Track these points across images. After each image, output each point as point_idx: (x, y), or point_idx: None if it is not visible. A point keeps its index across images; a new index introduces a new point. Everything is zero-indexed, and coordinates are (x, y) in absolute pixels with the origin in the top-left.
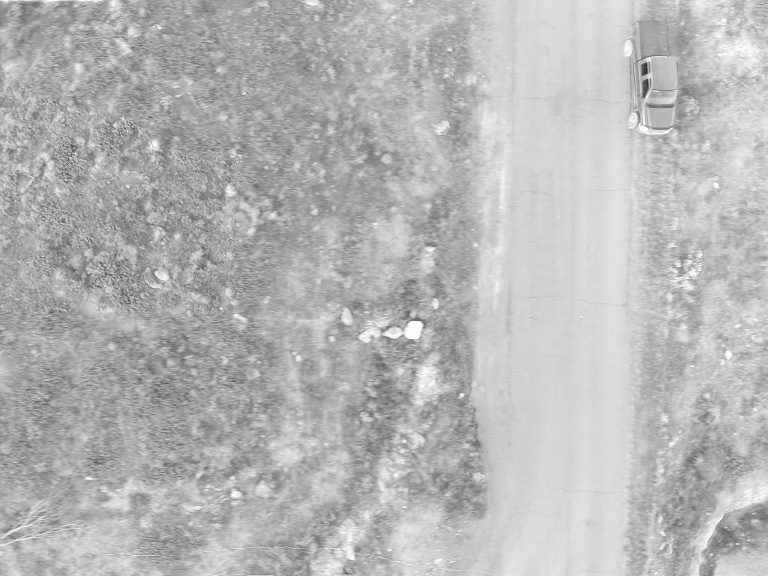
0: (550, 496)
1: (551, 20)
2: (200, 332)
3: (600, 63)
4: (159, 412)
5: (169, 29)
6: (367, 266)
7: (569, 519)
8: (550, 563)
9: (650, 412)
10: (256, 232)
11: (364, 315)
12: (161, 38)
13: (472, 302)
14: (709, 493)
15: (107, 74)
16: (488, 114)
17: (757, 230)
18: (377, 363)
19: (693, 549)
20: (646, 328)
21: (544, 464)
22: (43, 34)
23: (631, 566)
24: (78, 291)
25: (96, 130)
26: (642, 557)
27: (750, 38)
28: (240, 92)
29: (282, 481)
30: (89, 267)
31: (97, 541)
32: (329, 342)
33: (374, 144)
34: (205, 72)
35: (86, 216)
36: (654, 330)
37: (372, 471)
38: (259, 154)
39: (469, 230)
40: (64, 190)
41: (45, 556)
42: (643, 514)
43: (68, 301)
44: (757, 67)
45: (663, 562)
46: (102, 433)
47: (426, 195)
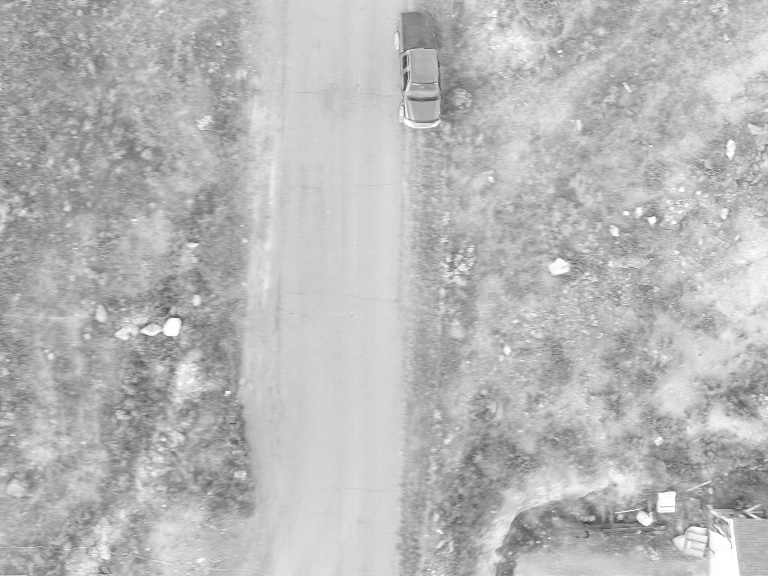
0: (320, 494)
1: (323, 13)
2: None
3: (372, 56)
4: None
5: None
6: (125, 263)
7: (340, 517)
8: (321, 562)
9: (423, 409)
10: (7, 229)
11: (119, 312)
12: None
13: (240, 298)
14: (493, 491)
15: None
16: (258, 109)
17: (534, 224)
18: (136, 360)
19: (480, 547)
20: (418, 324)
21: (314, 462)
22: None
23: (404, 565)
24: None
25: None
26: (416, 556)
27: (522, 30)
28: None
29: (36, 480)
30: None
31: None
32: (83, 339)
33: (134, 139)
34: None
35: None
36: (427, 326)
37: (130, 470)
38: (11, 150)
39: (237, 226)
40: None
41: None
42: (416, 512)
43: None
44: (532, 59)
45: (442, 561)
46: None
47: (190, 191)
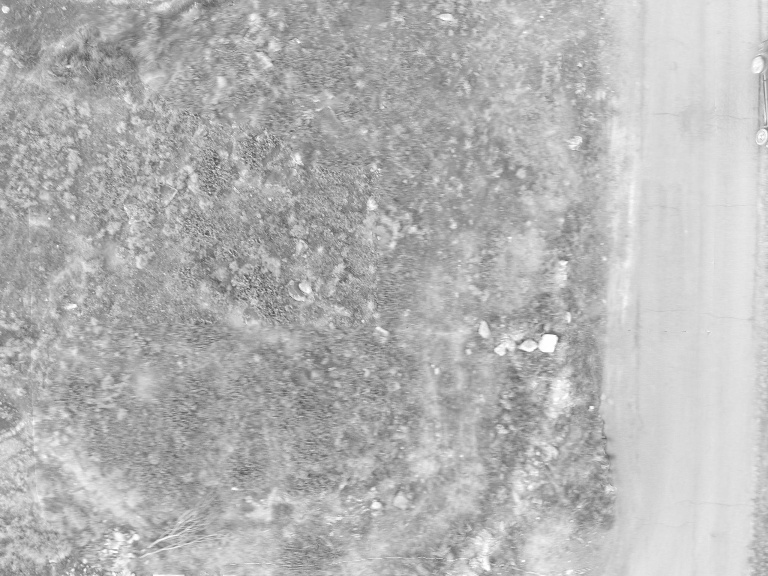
0: (677, 508)
1: (679, 36)
2: (343, 344)
3: (728, 79)
4: (303, 423)
5: (308, 43)
6: (502, 280)
7: (695, 531)
8: (676, 574)
9: None
10: (396, 245)
11: (501, 328)
12: (301, 52)
13: (601, 315)
14: None
15: (249, 88)
16: (617, 129)
17: None
18: (511, 376)
19: None
20: None
21: (671, 476)
22: (182, 47)
23: None
24: (223, 303)
25: (238, 143)
26: (766, 569)
27: None
28: (379, 106)
29: (419, 492)
30: (234, 279)
31: (240, 550)
32: (466, 355)
33: (509, 159)
34: (344, 86)
35: (229, 229)
36: None
37: (506, 483)
38: (399, 168)
39: (598, 244)
40: (208, 203)
41: (190, 565)
42: (767, 527)
43: (213, 313)
44: None
45: None
46: (247, 444)
47: (558, 209)
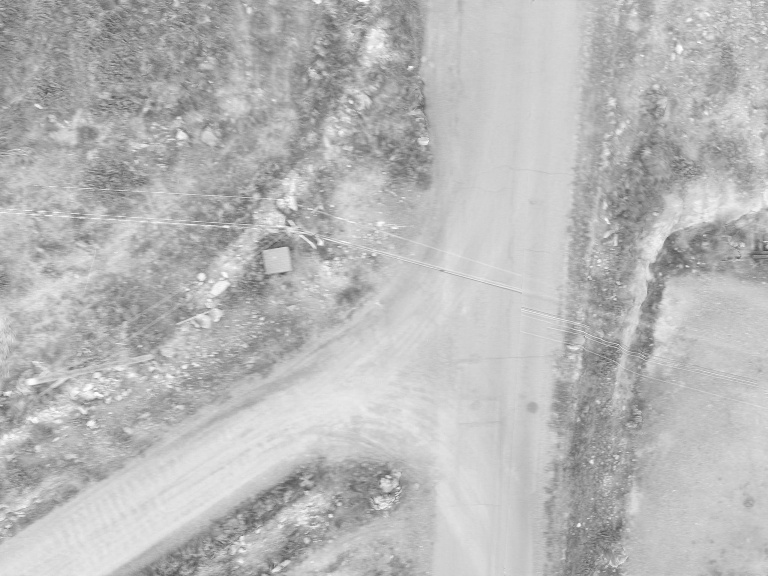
0: (495, 173)
1: None
2: None
3: None
4: (109, 46)
5: None
6: None
7: (513, 197)
8: (493, 240)
9: (598, 96)
10: None
11: None
12: None
13: None
14: (657, 193)
15: None
16: None
17: None
18: (327, 24)
19: (639, 251)
20: (597, 13)
21: (490, 141)
22: None
23: (574, 247)
24: None
25: None
26: (585, 239)
27: None
28: None
29: (229, 132)
30: None
31: (45, 173)
32: None
33: None
34: None
35: None
36: (605, 15)
37: (318, 129)
38: None
39: None
40: None
41: None
42: (587, 196)
43: None
44: None
45: (607, 252)
46: (53, 64)
47: None
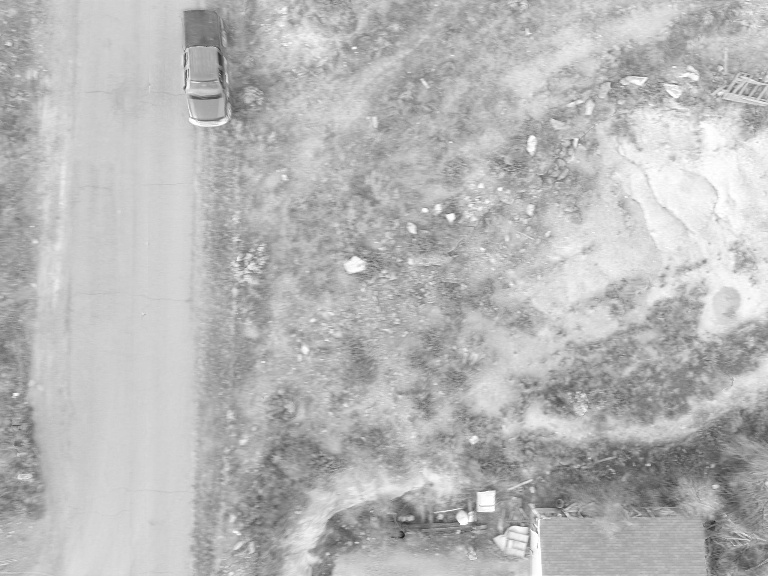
0: (112, 496)
1: (114, 12)
2: None
3: (163, 55)
4: None
5: None
6: None
7: (132, 519)
8: (113, 564)
9: (216, 409)
10: None
11: None
12: None
13: (30, 300)
14: (297, 491)
15: None
16: (49, 109)
17: (330, 222)
18: None
19: (286, 548)
20: (211, 324)
21: (105, 464)
22: None
23: (198, 566)
24: None
25: None
26: (210, 557)
27: (313, 27)
28: None
29: None
30: None
31: None
32: None
33: None
34: None
35: None
36: (219, 326)
37: None
38: None
39: (27, 227)
40: None
41: None
42: (209, 513)
43: None
44: (326, 56)
45: (241, 562)
46: None
47: None
